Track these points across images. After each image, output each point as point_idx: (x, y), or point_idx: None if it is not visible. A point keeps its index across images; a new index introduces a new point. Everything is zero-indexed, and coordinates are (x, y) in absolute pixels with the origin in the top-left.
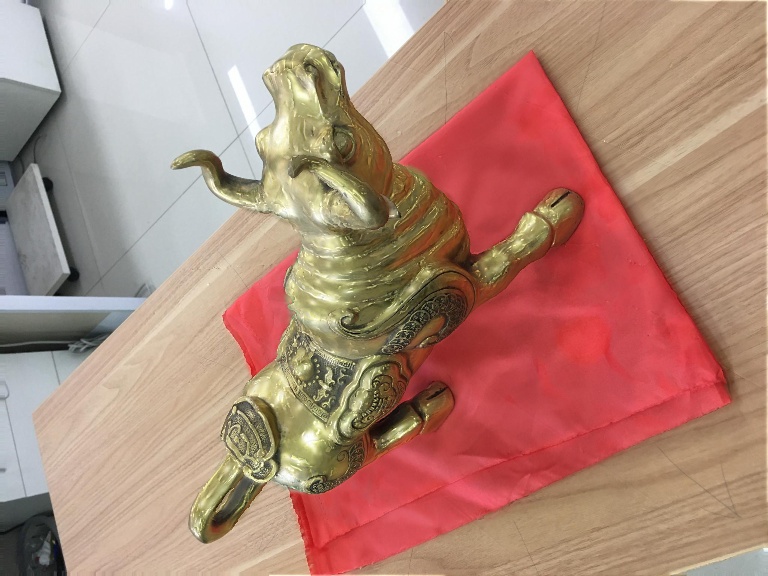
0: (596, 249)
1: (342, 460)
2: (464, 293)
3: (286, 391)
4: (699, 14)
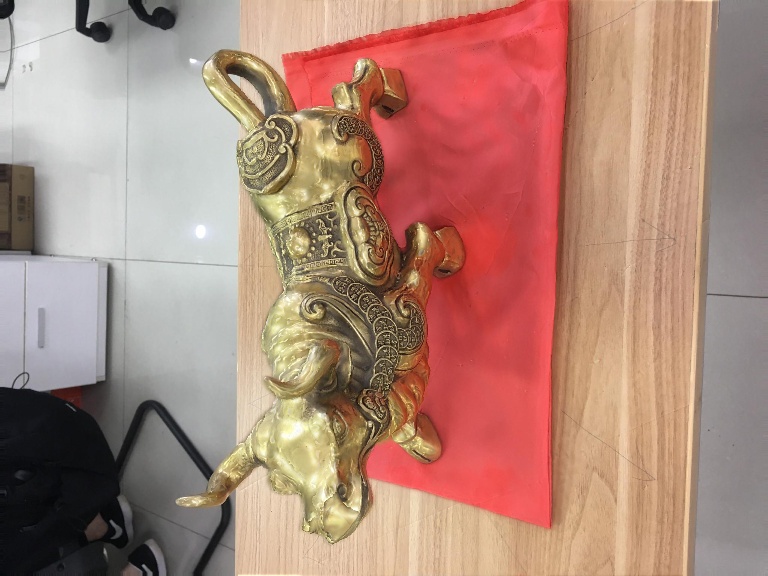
0: (391, 444)
1: None
2: None
3: (293, 207)
4: None
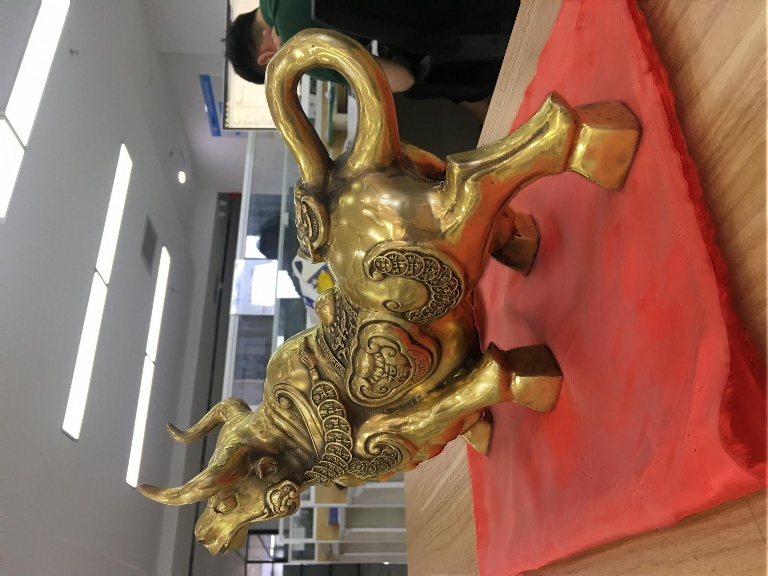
0: None
1: None
2: None
3: None
4: None
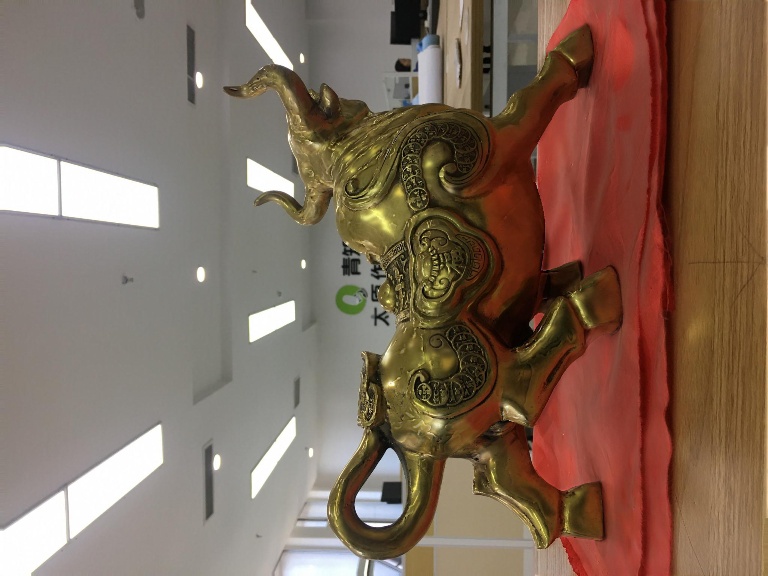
0: None
1: (440, 347)
2: (458, 121)
3: None
4: None
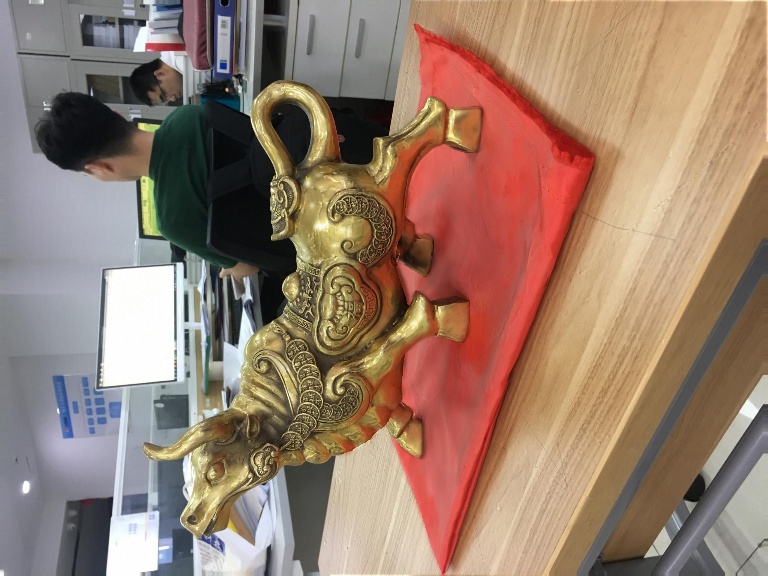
0: None
1: None
2: None
3: None
4: (411, 575)
